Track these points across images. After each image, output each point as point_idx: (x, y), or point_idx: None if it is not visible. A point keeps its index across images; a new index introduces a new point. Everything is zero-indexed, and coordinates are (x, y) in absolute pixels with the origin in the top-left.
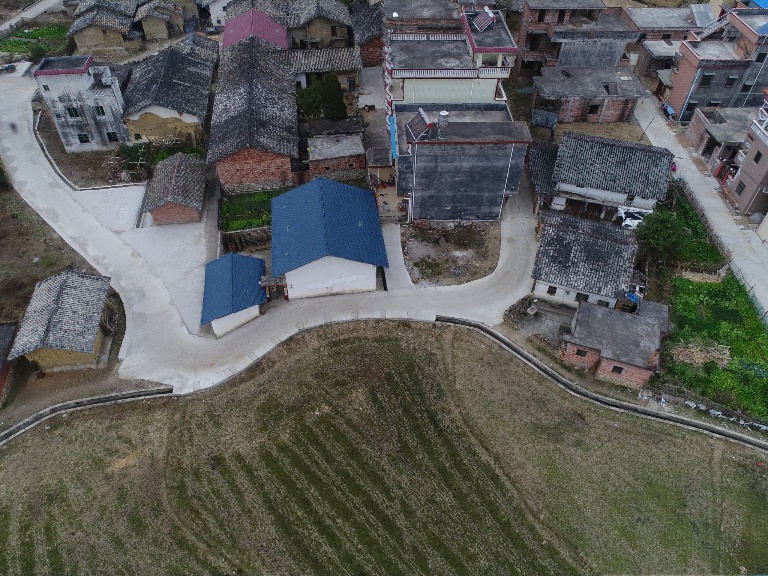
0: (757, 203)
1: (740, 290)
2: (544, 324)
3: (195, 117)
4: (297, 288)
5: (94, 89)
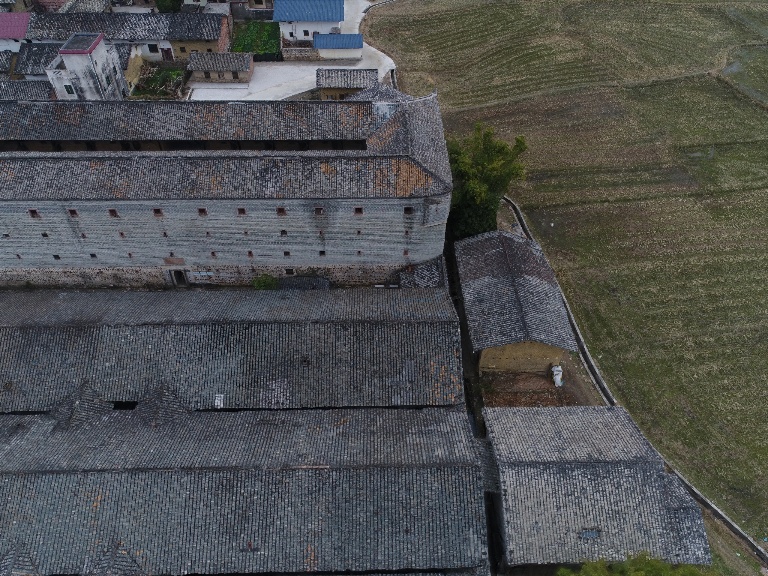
0: None
1: None
2: None
3: (140, 49)
4: None
5: (108, 51)
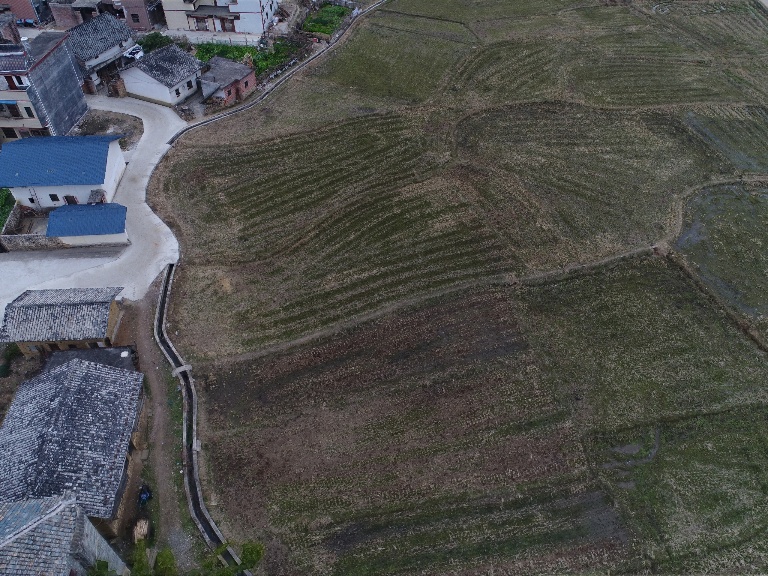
0: (151, 19)
1: (209, 45)
2: (196, 108)
3: None
4: (107, 192)
5: None
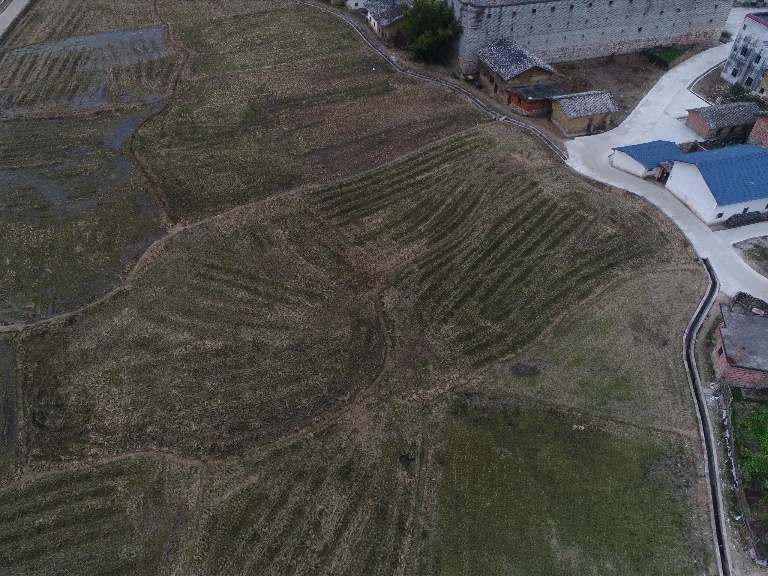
0: None
1: None
2: None
3: None
4: (673, 181)
5: None
